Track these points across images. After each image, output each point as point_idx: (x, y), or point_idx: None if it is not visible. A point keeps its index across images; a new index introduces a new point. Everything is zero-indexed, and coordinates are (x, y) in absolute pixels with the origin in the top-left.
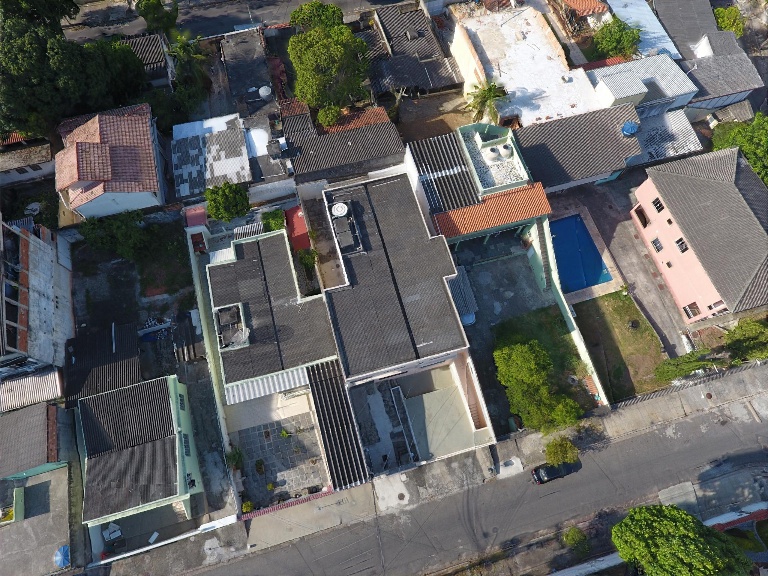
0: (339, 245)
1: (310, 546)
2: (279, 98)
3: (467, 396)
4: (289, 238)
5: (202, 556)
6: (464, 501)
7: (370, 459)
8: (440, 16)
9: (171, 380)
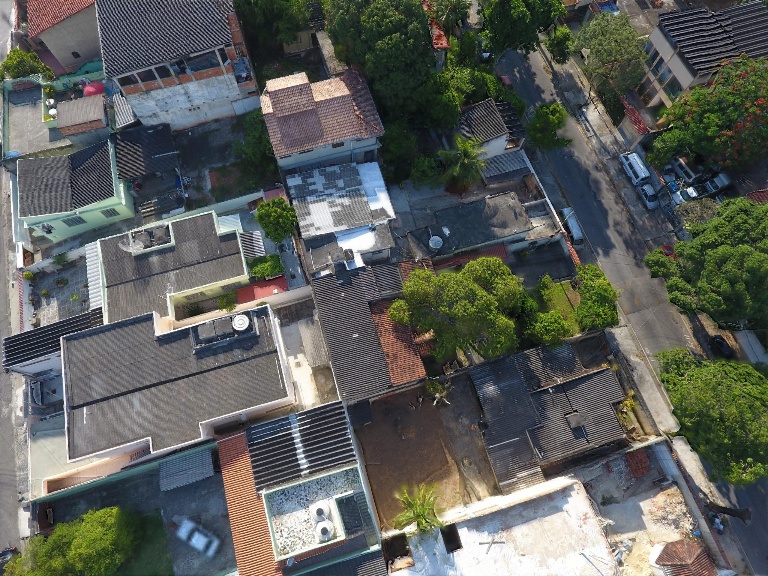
0: (202, 324)
1: (3, 330)
2: (445, 261)
3: (89, 476)
4: (253, 283)
5: (15, 250)
6: (6, 471)
7: (43, 375)
8: (660, 472)
9: (118, 201)
